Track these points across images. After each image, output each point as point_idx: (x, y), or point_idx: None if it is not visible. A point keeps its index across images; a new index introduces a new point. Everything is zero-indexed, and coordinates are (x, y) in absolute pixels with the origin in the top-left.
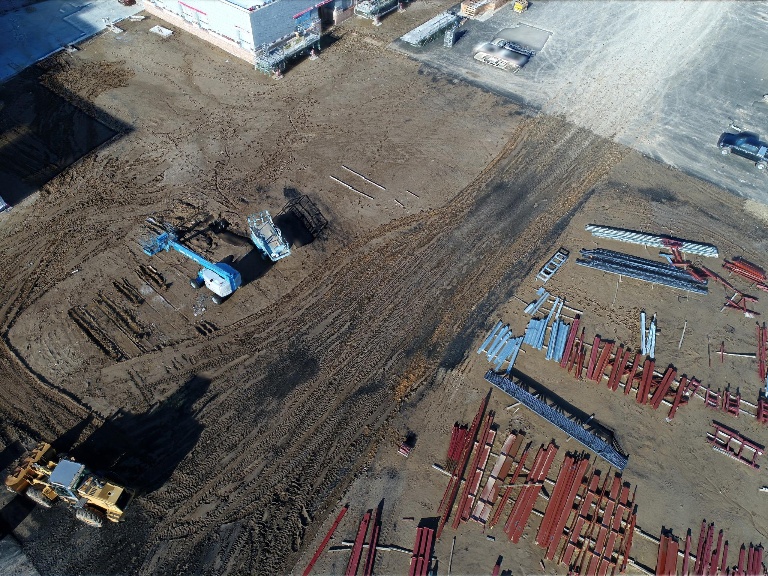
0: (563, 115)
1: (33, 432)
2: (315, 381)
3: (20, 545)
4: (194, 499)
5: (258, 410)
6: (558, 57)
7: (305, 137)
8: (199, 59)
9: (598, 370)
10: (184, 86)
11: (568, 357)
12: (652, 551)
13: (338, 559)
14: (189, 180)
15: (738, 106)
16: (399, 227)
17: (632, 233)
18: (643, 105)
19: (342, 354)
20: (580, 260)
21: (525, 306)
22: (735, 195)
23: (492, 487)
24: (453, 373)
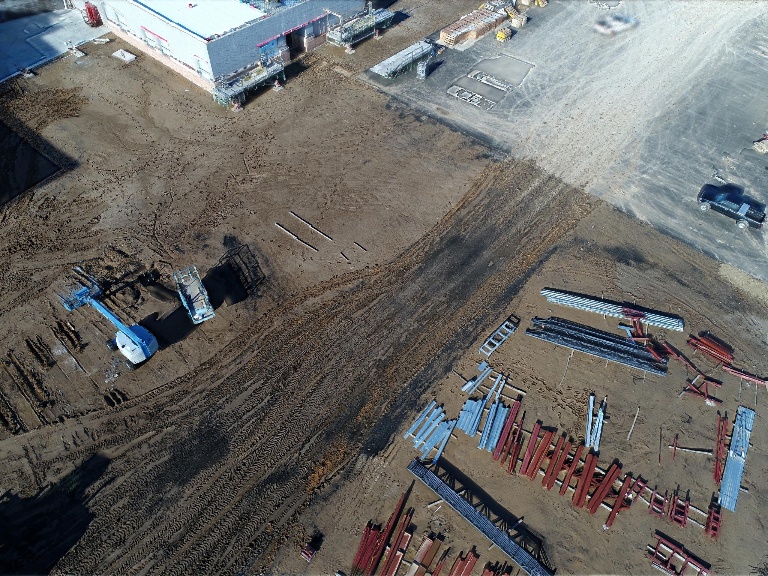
0: (533, 160)
1: None
2: (222, 466)
3: None
4: None
5: (155, 498)
6: (537, 93)
7: (256, 178)
8: (158, 87)
9: (534, 464)
10: (138, 117)
11: (502, 447)
12: None
13: None
14: (126, 224)
15: (725, 153)
16: (340, 285)
17: (591, 300)
18: (621, 150)
19: (256, 434)
20: (531, 330)
21: (464, 383)
22: (710, 258)
23: None
24: (374, 461)
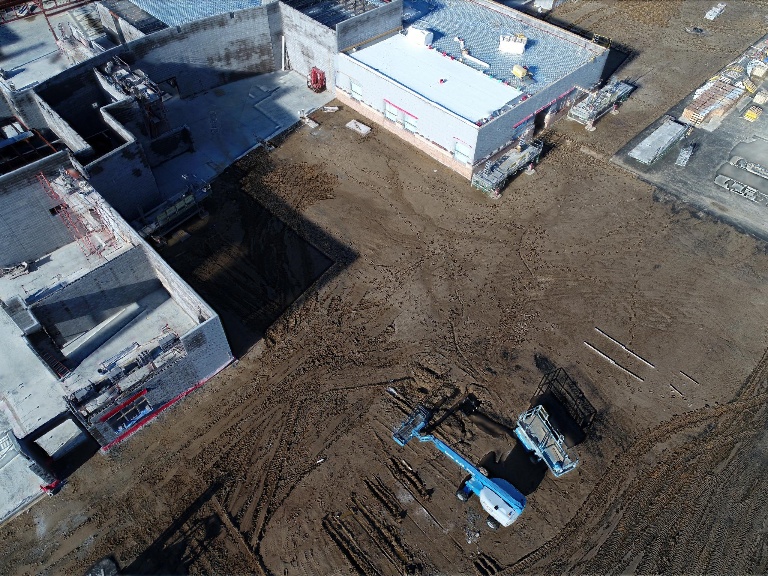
0: None
1: None
2: None
3: None
4: None
5: None
6: None
7: (542, 282)
8: (405, 166)
9: None
10: (395, 202)
11: None
12: None
13: None
14: (424, 335)
15: None
16: (685, 428)
17: None
18: None
19: None
20: None
21: None
22: None
23: None
24: None
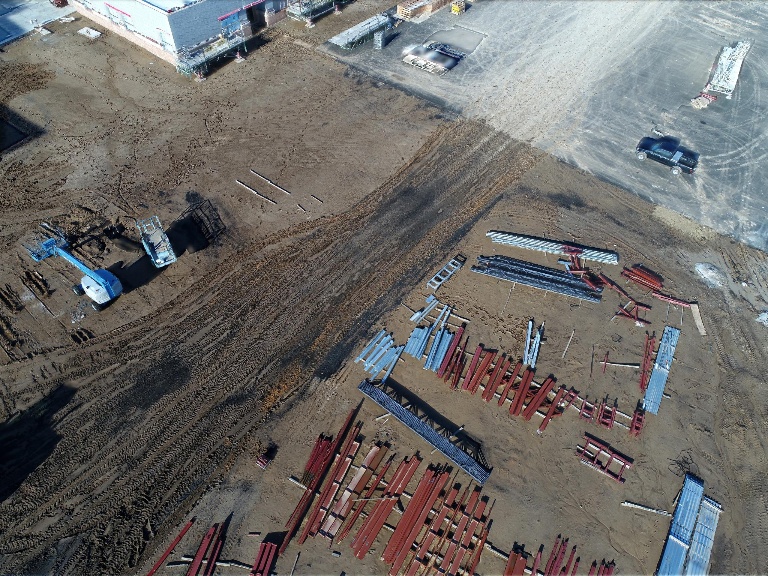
0: (483, 119)
1: None
2: (183, 391)
3: None
4: (38, 512)
5: (120, 420)
6: (488, 60)
7: (218, 141)
8: (123, 61)
9: (475, 380)
10: (103, 88)
11: (446, 367)
12: (500, 568)
13: (175, 575)
14: (92, 184)
15: (663, 110)
16: (297, 233)
17: (533, 239)
18: (566, 109)
19: (216, 363)
20: (476, 267)
21: (412, 314)
22: (646, 201)
23: (346, 501)
24: (327, 383)
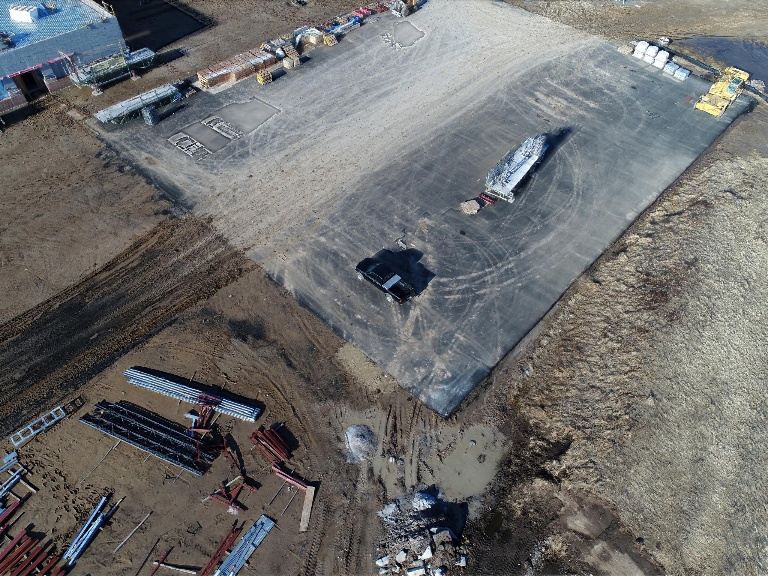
0: (211, 218)
1: None
2: None
3: None
4: None
5: None
6: (263, 142)
7: None
8: None
9: None
10: None
11: None
12: None
13: None
14: None
15: (425, 214)
16: None
17: (172, 383)
18: (313, 209)
19: None
20: (89, 416)
21: None
22: (337, 336)
23: None
24: None
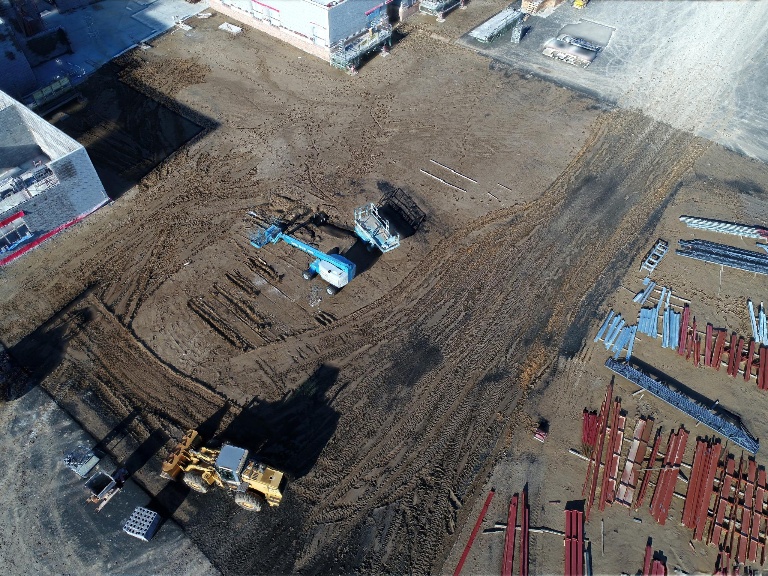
0: (640, 109)
1: (174, 420)
2: (441, 369)
3: (182, 529)
4: (343, 484)
5: (390, 398)
6: (625, 52)
7: (389, 132)
8: (272, 55)
9: (716, 357)
10: (261, 82)
11: (685, 345)
12: None
13: (493, 541)
14: (282, 174)
15: None
16: (497, 219)
17: (727, 224)
18: (716, 99)
19: (462, 343)
20: (680, 251)
21: (633, 296)
22: None
23: (631, 471)
24: (573, 361)
